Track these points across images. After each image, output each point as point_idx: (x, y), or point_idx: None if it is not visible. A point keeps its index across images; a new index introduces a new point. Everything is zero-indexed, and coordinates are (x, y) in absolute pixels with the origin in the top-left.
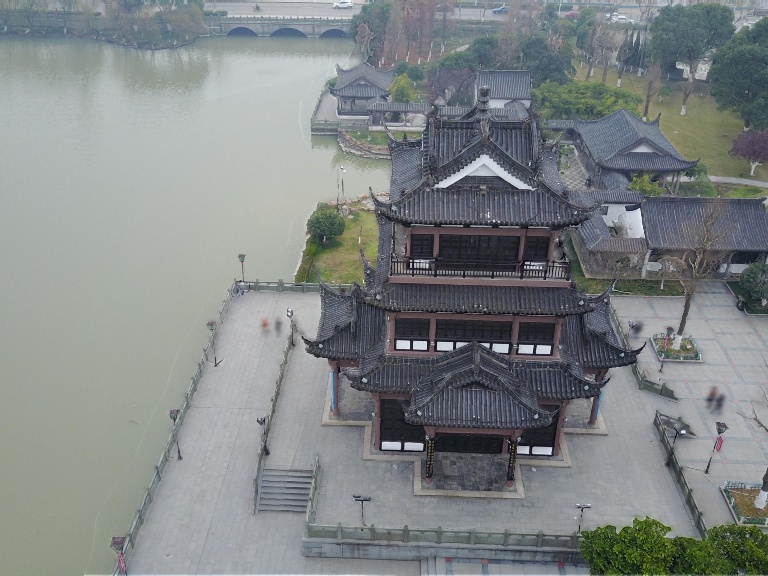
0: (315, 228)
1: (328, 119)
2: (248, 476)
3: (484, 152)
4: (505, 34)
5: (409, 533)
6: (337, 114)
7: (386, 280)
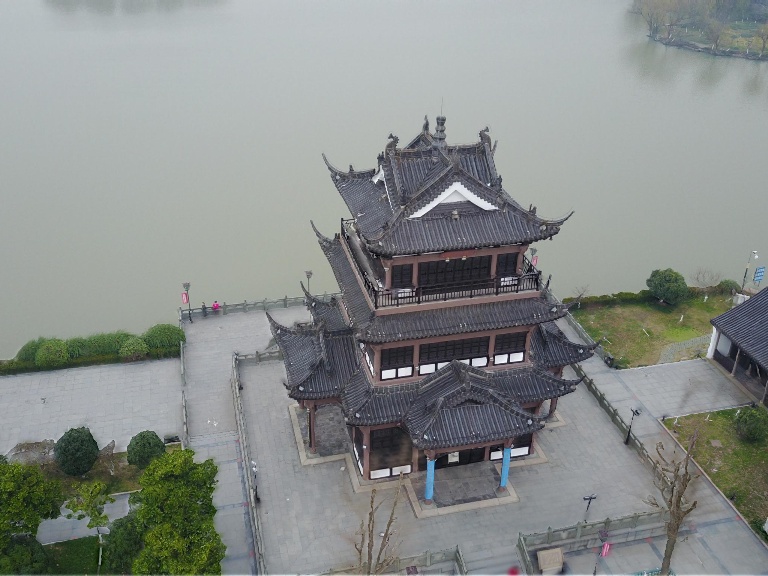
0: (649, 280)
1: None
2: None
3: None
4: None
5: None
6: None
7: None
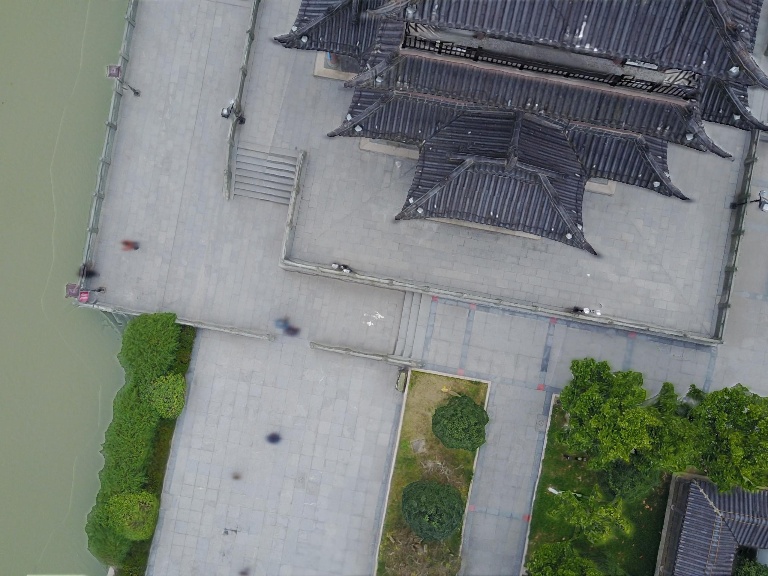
0: None
1: None
2: (221, 135)
3: None
4: None
5: None
6: None
7: (395, 53)
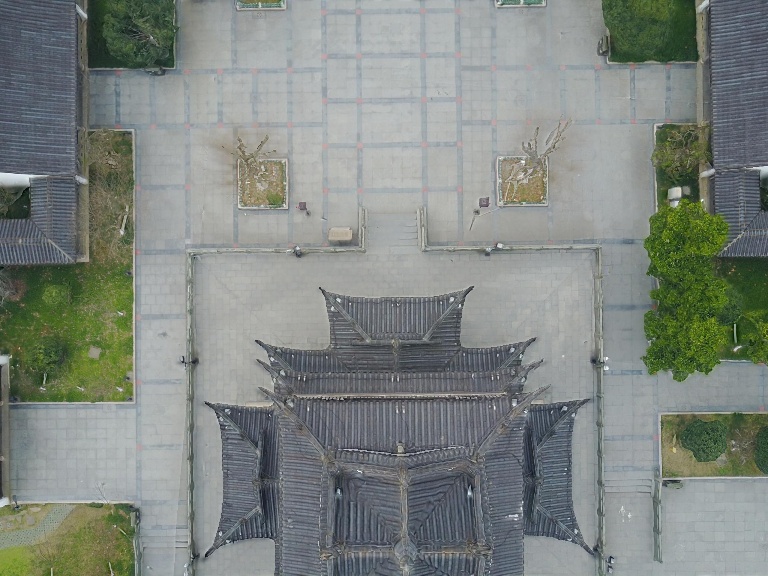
0: None
1: None
2: None
3: None
4: None
5: None
6: None
7: None
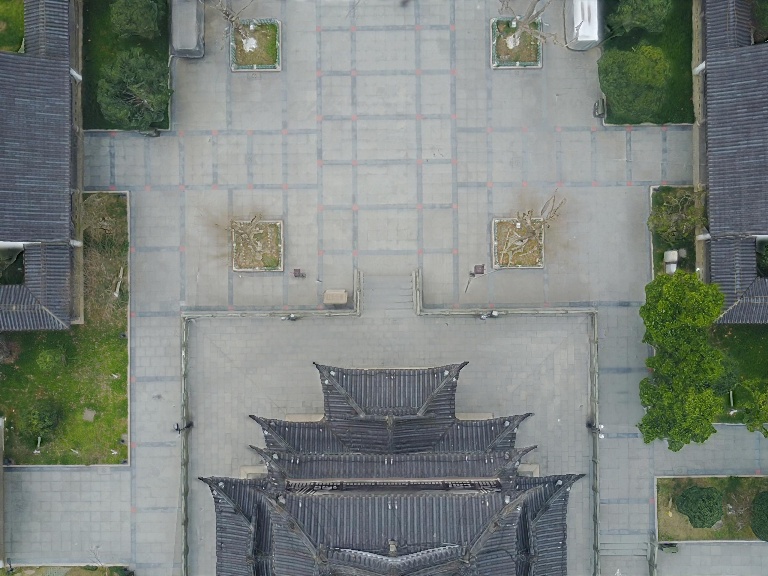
0: None
1: None
2: None
3: None
4: None
5: None
6: None
7: None
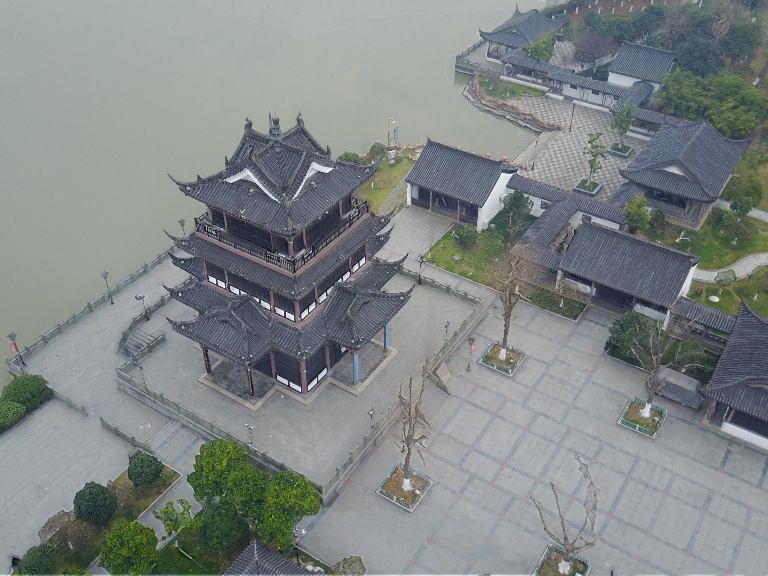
0: None
1: (471, 60)
2: None
3: (247, 167)
4: (675, 7)
5: (164, 399)
6: (486, 56)
7: None
